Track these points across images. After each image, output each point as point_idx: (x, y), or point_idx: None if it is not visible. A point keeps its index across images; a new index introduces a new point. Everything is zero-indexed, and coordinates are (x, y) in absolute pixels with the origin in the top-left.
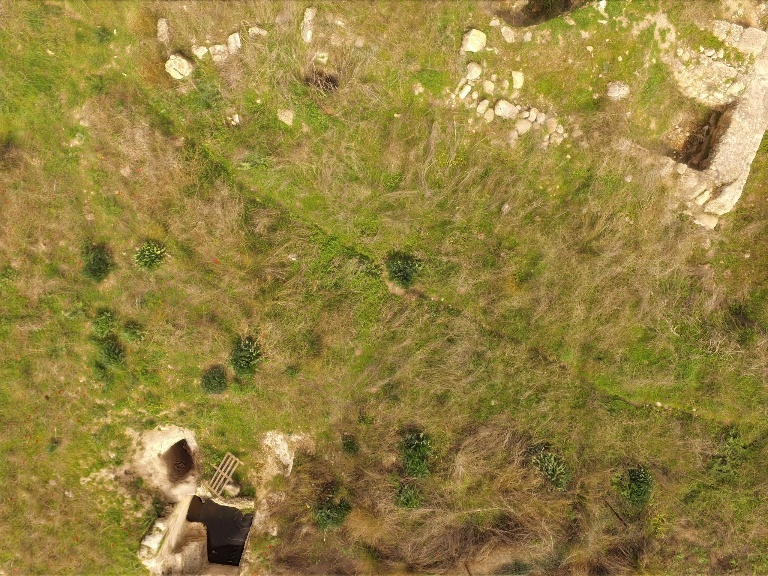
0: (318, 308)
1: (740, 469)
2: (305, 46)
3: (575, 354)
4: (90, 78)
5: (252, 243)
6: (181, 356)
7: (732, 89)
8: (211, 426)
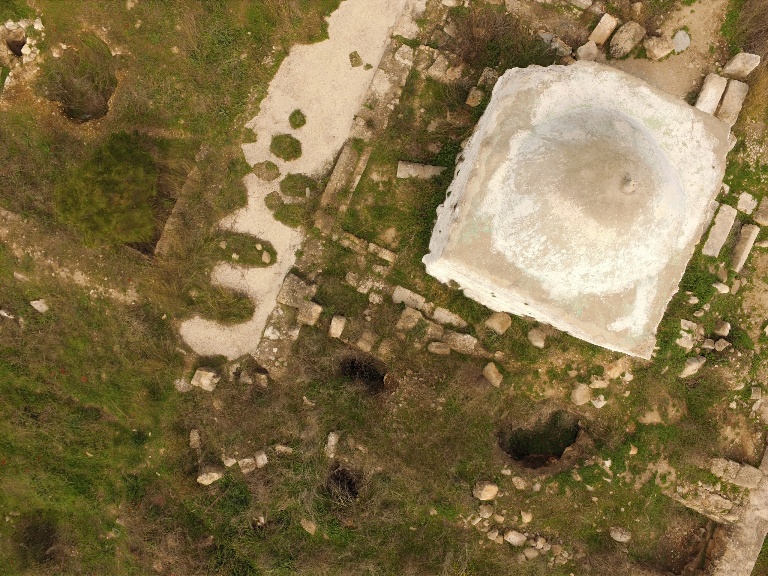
0: None
1: None
2: (328, 462)
3: None
4: (126, 479)
5: None
6: None
7: (728, 517)
8: None
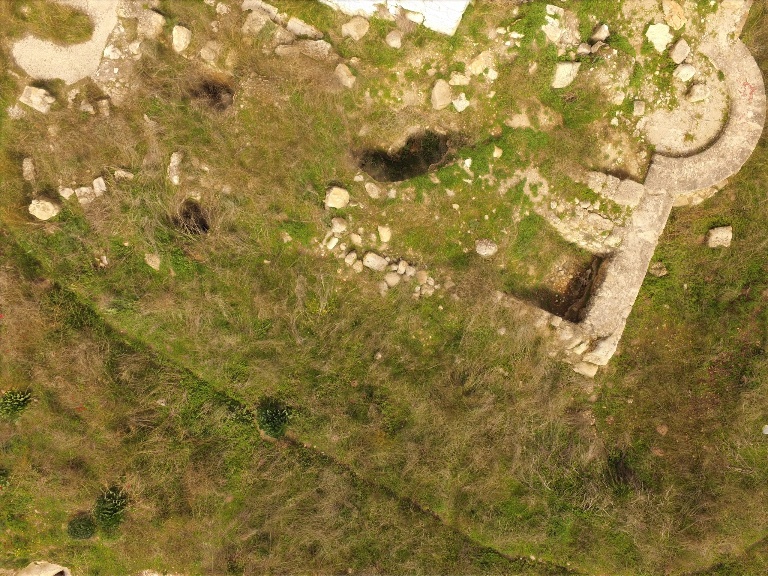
0: (187, 455)
1: None
2: (173, 189)
3: (447, 506)
4: None
5: (117, 391)
6: (48, 501)
7: (609, 241)
8: (85, 565)
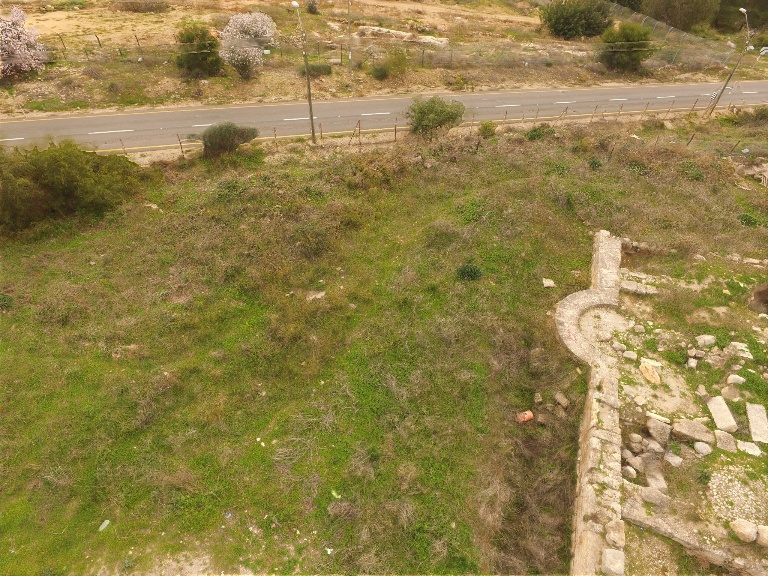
0: None
1: (554, 167)
2: None
3: None
4: None
5: None
6: None
7: None
8: None
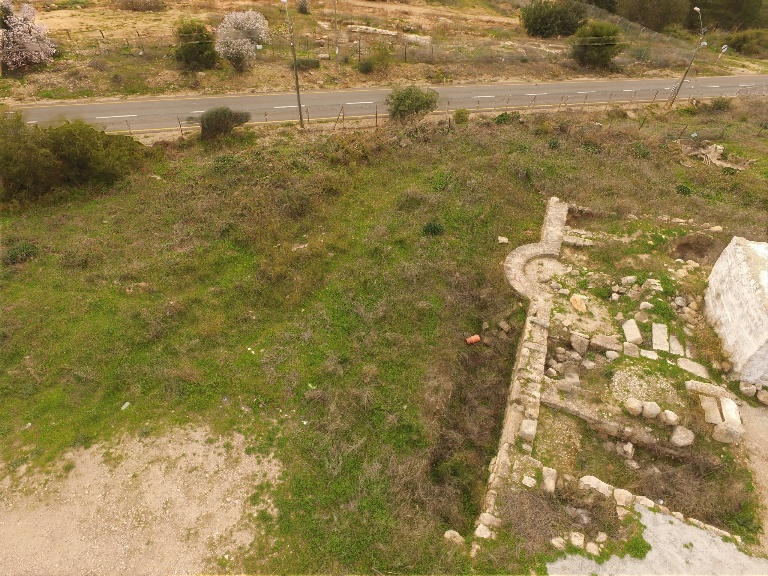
0: None
1: None
2: None
3: None
4: None
5: None
6: None
7: None
8: None
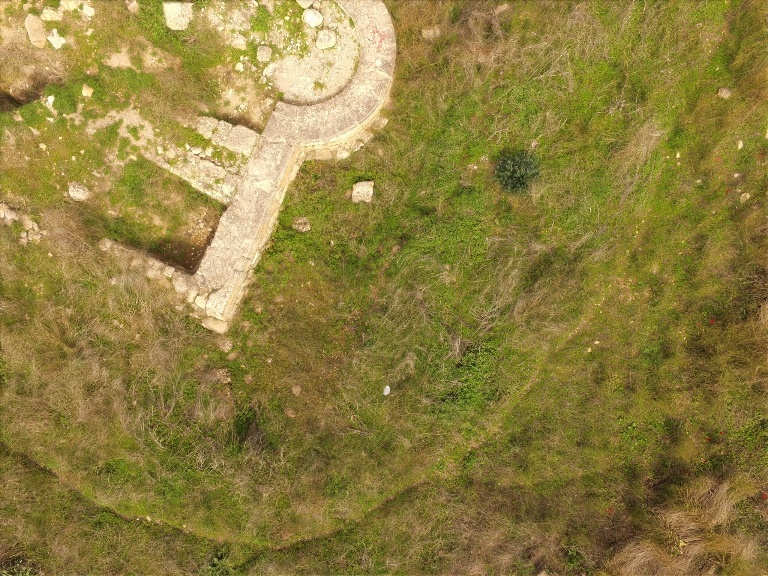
0: None
1: None
2: None
3: (61, 462)
4: None
5: None
6: None
7: (224, 189)
8: None
